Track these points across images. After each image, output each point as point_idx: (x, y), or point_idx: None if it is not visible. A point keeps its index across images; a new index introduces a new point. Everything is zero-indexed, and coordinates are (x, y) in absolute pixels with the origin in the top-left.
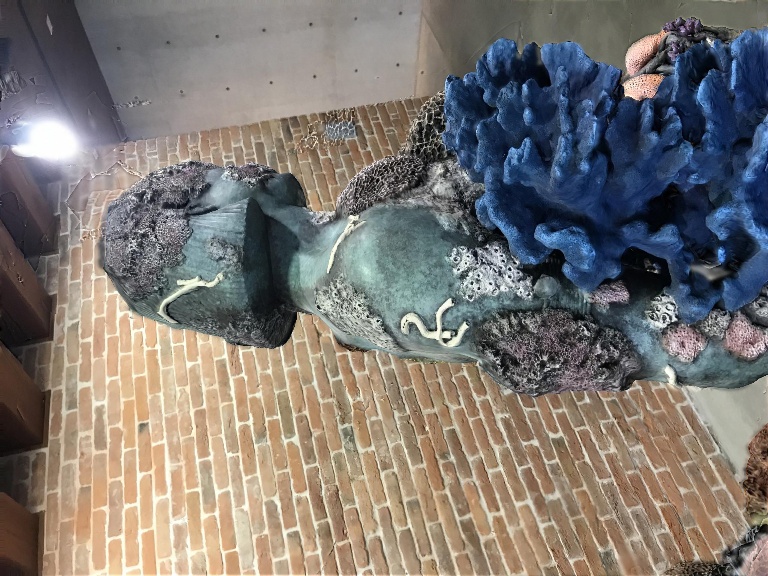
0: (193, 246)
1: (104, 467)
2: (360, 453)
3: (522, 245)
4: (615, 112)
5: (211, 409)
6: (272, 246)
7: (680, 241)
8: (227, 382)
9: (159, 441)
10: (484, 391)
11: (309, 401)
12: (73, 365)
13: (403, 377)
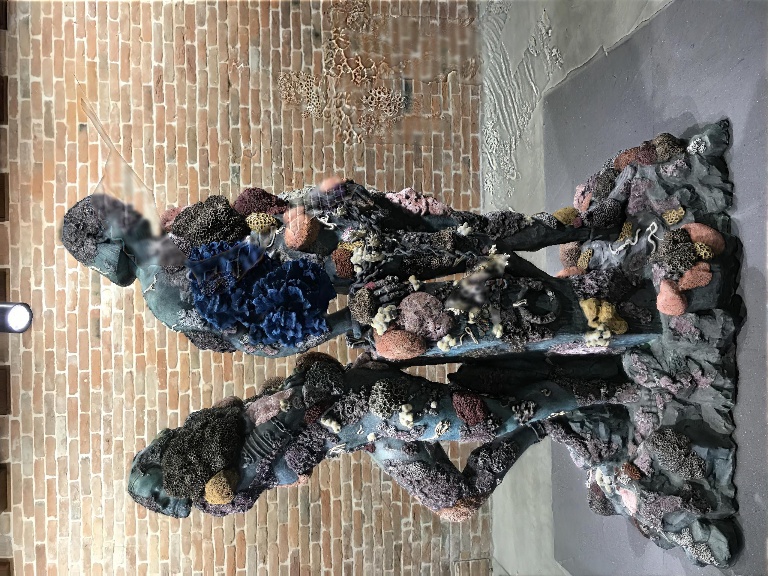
0: (98, 259)
1: (52, 152)
2: (241, 187)
3: (202, 314)
4: (235, 291)
5: (136, 126)
6: (130, 261)
7: (253, 324)
8: (151, 107)
9: (94, 142)
10: (343, 164)
11: (211, 140)
12: (25, 58)
13: (287, 137)
